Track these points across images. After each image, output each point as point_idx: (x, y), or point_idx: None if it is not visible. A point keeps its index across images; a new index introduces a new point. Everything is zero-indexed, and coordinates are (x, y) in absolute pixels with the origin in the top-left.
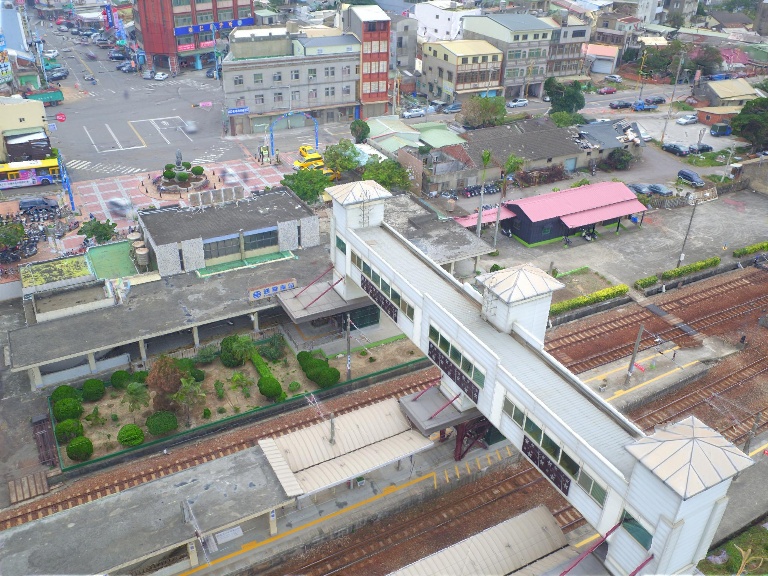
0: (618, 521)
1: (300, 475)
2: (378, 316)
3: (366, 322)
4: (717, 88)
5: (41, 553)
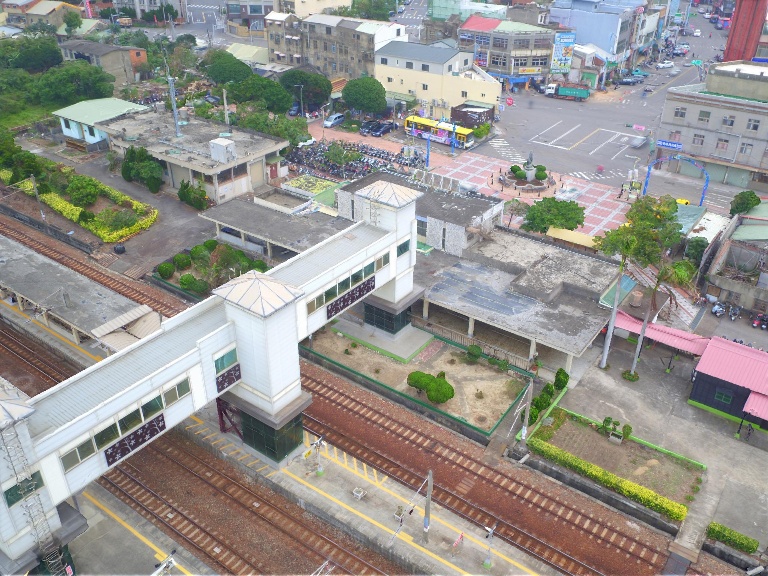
0: None
1: (123, 334)
2: (394, 327)
3: (383, 325)
4: None
5: (35, 274)
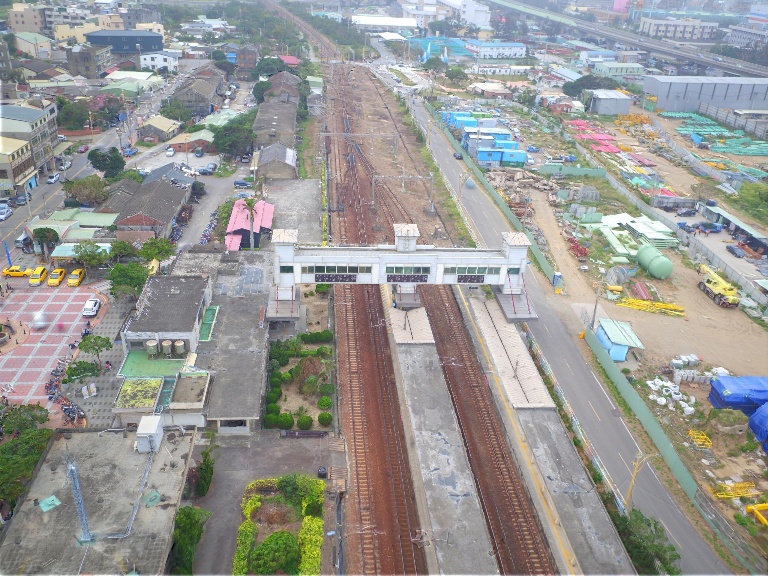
0: (506, 274)
1: None
2: None
3: None
4: (158, 126)
5: None
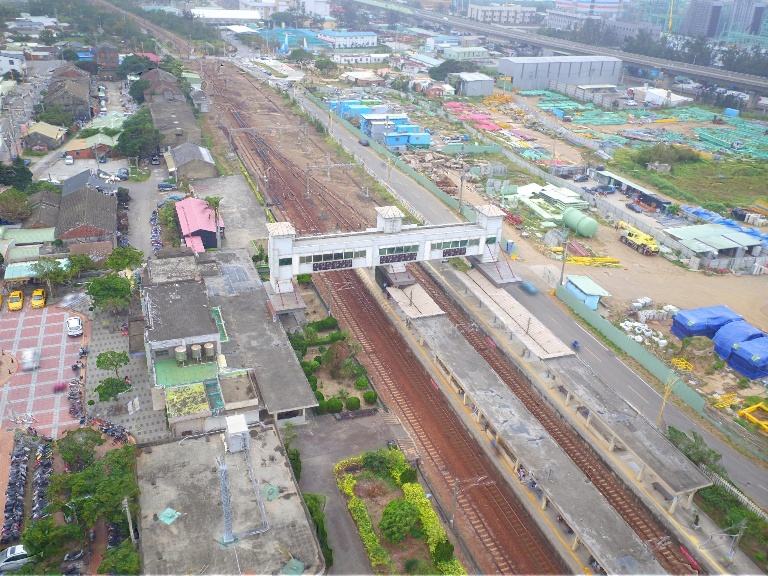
0: None
1: None
2: None
3: None
4: (45, 133)
5: None
